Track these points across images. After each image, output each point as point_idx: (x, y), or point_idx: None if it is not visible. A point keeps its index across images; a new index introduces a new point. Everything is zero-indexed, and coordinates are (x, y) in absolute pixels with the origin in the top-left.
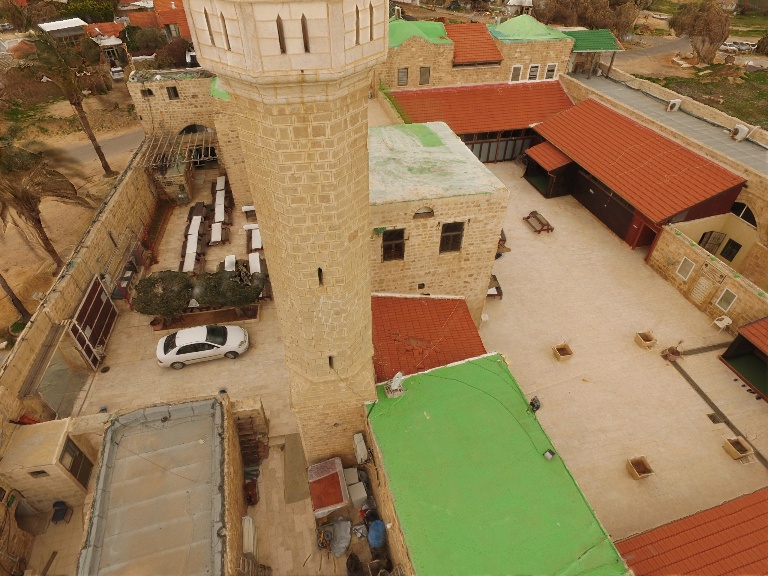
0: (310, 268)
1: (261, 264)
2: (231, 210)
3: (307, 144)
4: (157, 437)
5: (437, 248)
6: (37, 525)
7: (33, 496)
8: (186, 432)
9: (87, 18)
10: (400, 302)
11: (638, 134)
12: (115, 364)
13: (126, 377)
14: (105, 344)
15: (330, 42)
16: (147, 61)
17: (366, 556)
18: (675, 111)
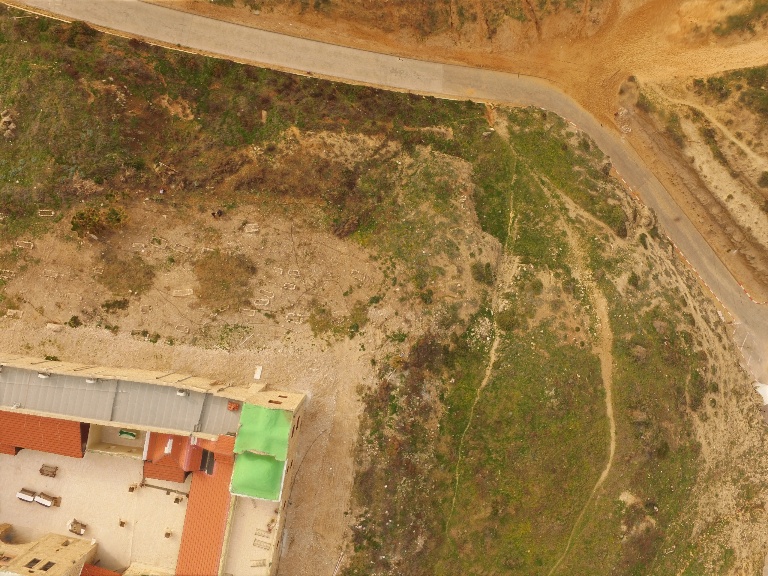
0: None
1: None
2: None
3: None
4: None
5: None
6: None
7: None
8: None
9: None
10: None
11: (16, 417)
12: None
13: None
14: None
15: None
16: None
17: None
18: (2, 369)
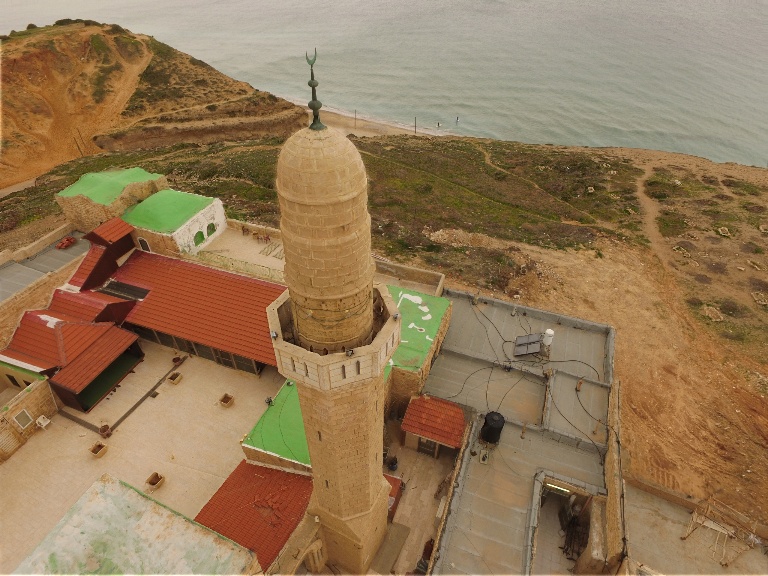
0: None
1: None
2: None
3: None
4: None
5: None
6: None
7: None
8: None
9: None
10: None
11: None
12: None
13: None
14: None
15: None
16: None
17: (383, 469)
18: None
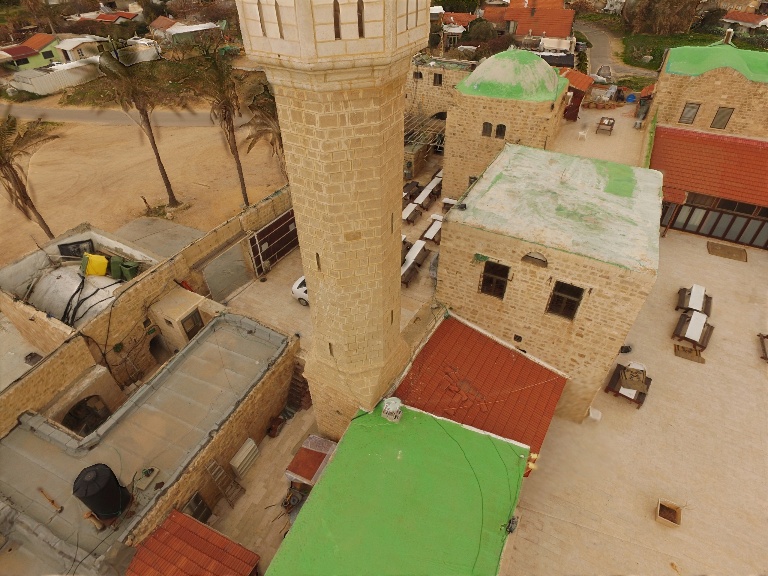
0: (310, 249)
1: (421, 253)
2: (436, 197)
3: (302, 129)
4: (237, 341)
5: (543, 305)
6: (164, 358)
7: (167, 337)
8: (254, 349)
9: (454, 7)
10: (487, 343)
11: None
12: (271, 279)
13: (270, 292)
14: (276, 262)
15: (298, 31)
16: (467, 51)
17: None
18: None
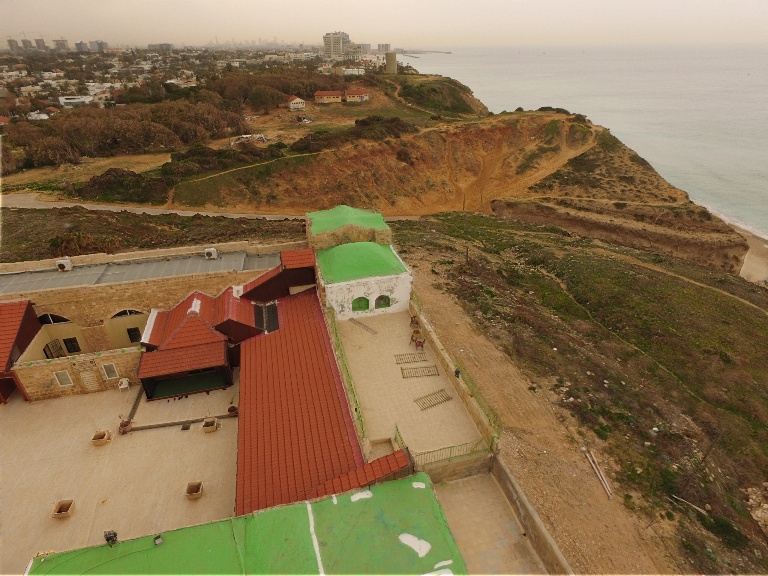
0: None
1: None
2: None
3: None
4: None
5: None
6: None
7: None
8: None
9: None
10: None
11: None
12: None
13: None
14: None
15: None
16: None
17: None
18: None
